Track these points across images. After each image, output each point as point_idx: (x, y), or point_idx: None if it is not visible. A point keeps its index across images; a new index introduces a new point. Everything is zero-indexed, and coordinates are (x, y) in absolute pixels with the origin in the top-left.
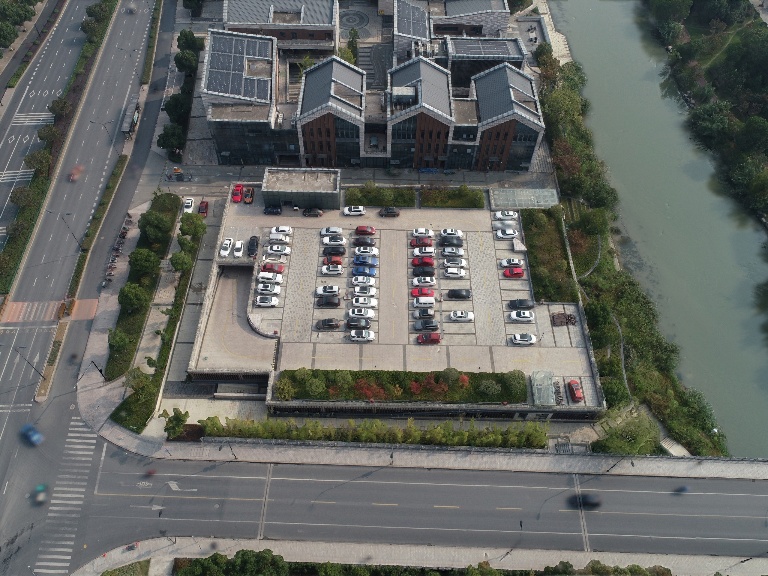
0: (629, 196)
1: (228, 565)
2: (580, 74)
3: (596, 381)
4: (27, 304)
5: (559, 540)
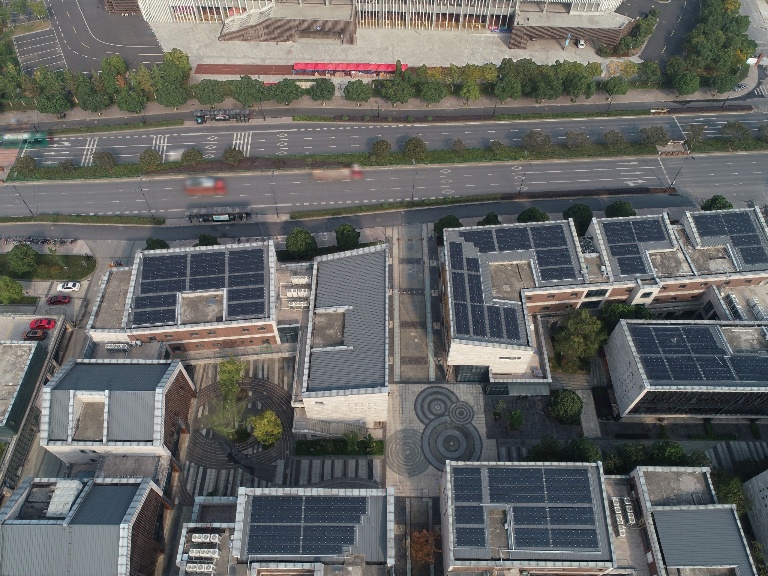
0: None
1: None
2: None
3: None
4: None
5: None
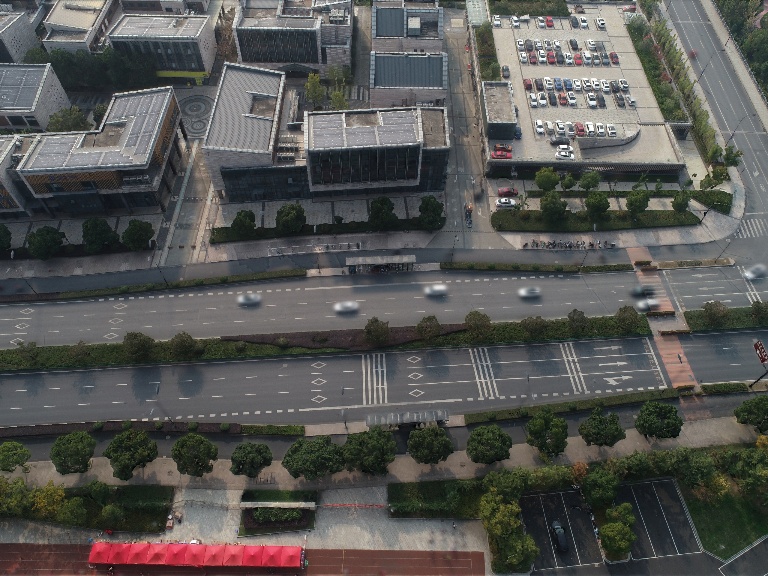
0: None
1: None
2: None
3: (620, 2)
4: (649, 299)
5: (710, 30)
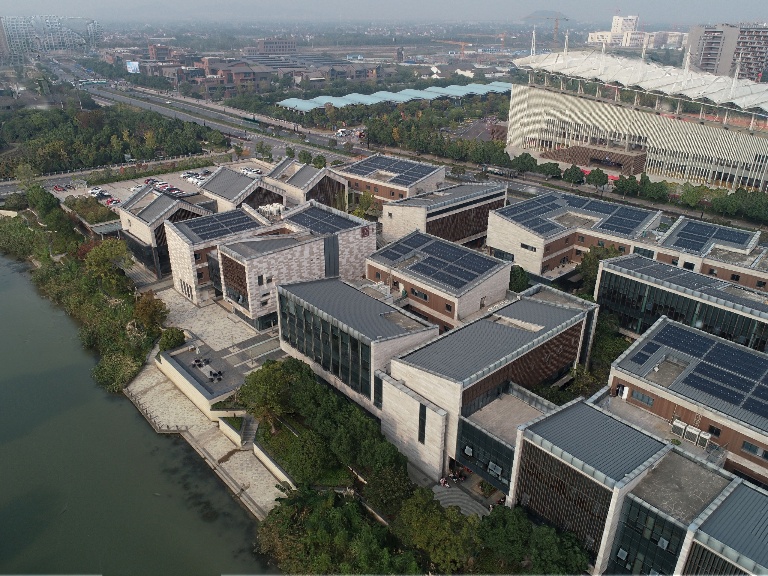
0: (19, 296)
1: (185, 145)
2: (106, 377)
3: None
4: None
5: None
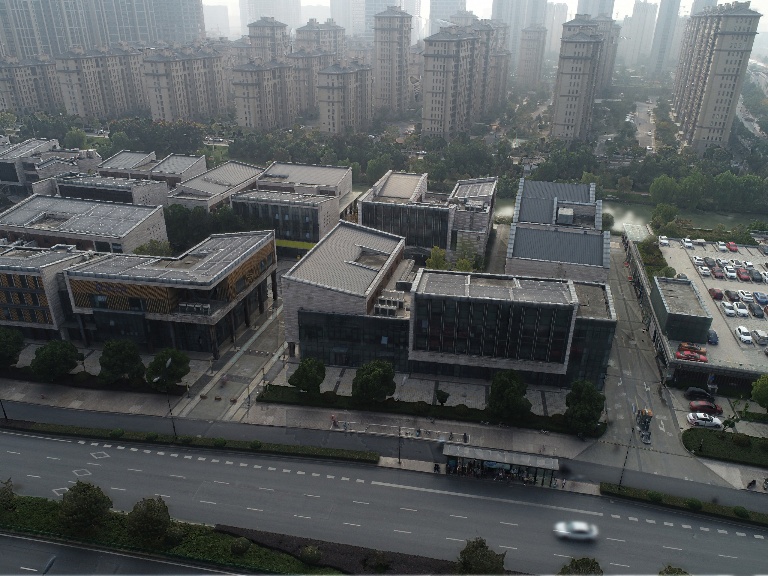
0: None
1: None
2: None
3: None
4: None
5: None
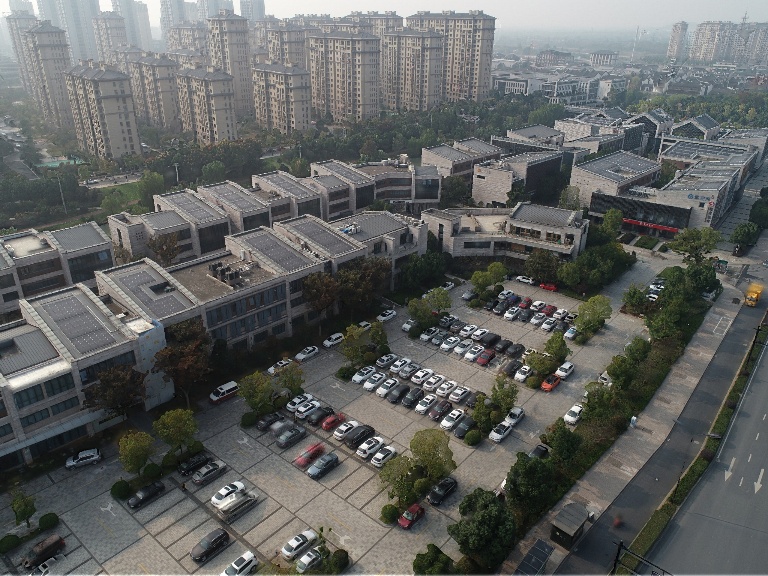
0: None
1: None
2: None
3: None
4: None
5: None
